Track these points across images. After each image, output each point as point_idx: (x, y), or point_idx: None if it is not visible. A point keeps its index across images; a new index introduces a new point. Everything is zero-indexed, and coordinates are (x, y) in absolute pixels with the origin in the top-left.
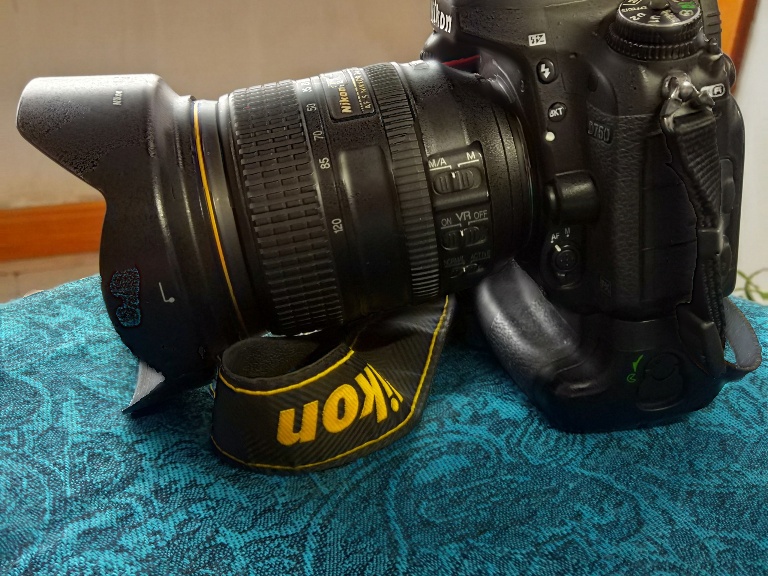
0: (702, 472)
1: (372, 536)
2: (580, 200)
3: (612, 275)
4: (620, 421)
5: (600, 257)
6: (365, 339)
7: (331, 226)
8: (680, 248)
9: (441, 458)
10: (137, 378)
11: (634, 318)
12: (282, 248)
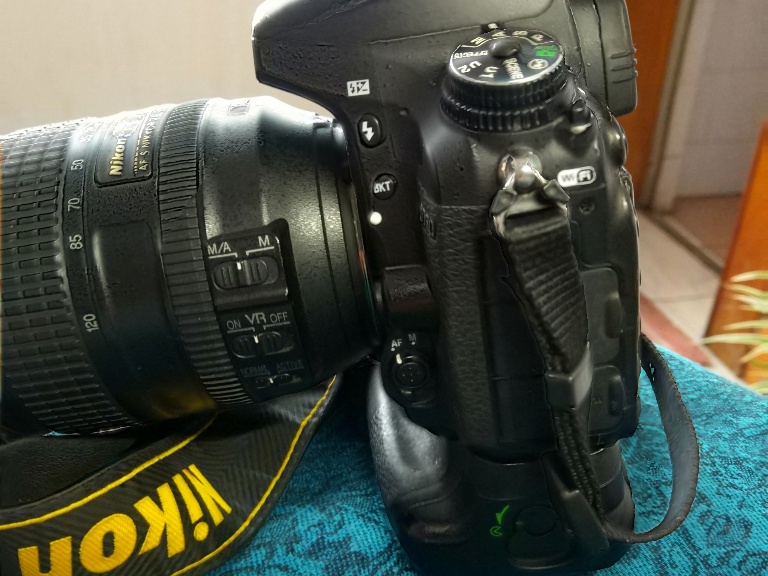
0: None
1: None
2: (413, 305)
3: (459, 405)
4: (495, 572)
5: (447, 378)
6: (221, 423)
7: (83, 323)
8: None
9: None
10: None
11: (496, 458)
12: (22, 347)
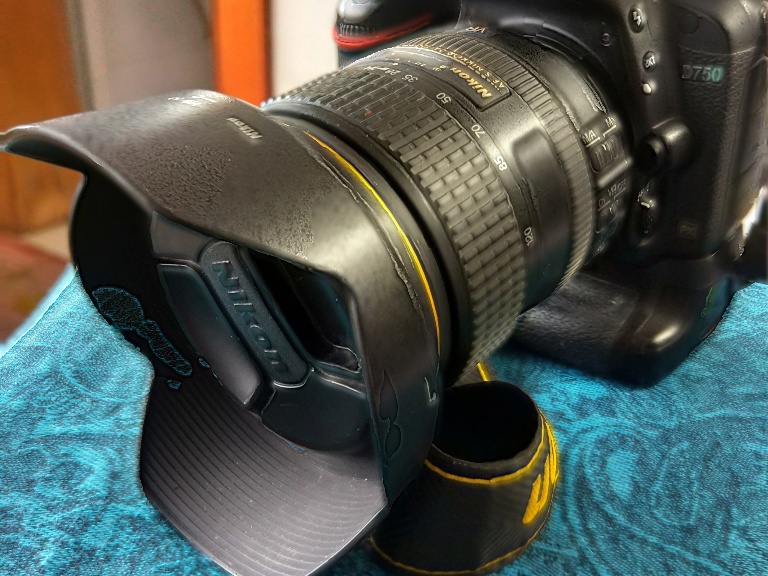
0: (767, 375)
1: (673, 570)
2: (678, 149)
3: (701, 217)
4: (676, 359)
5: (685, 203)
6: None
7: (524, 239)
8: (744, 175)
9: (607, 462)
10: (195, 545)
11: (706, 254)
12: (488, 283)
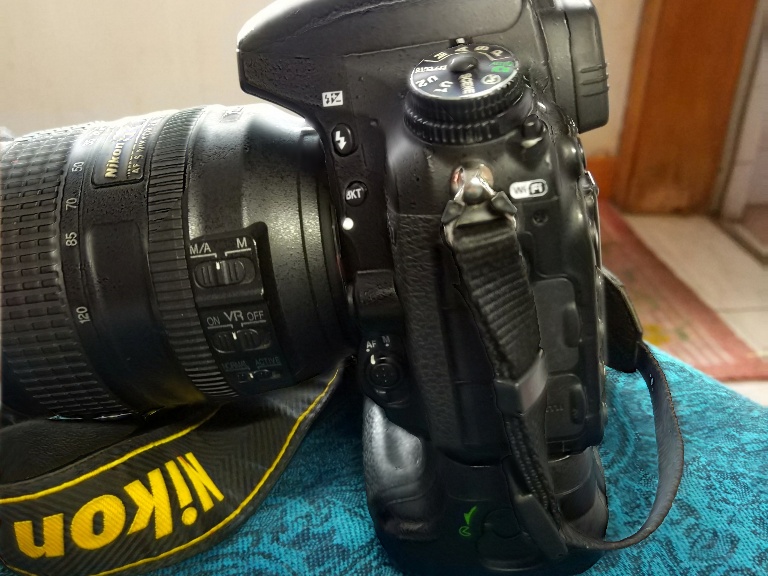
0: None
1: None
2: (382, 308)
3: None
4: (470, 572)
5: None
6: (223, 415)
7: (76, 314)
8: None
9: None
10: None
11: (463, 460)
12: (22, 335)
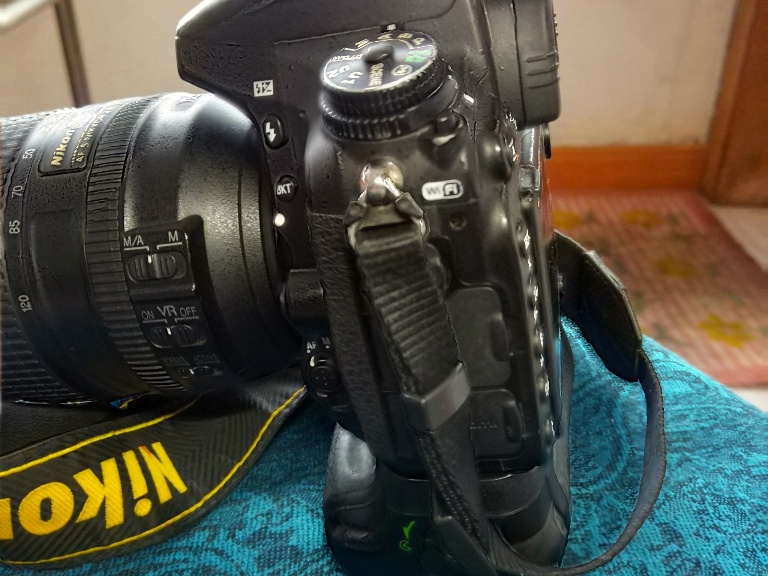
0: None
1: None
2: (312, 310)
3: None
4: None
5: None
6: (202, 405)
7: (19, 303)
8: None
9: None
10: None
11: (400, 472)
12: None
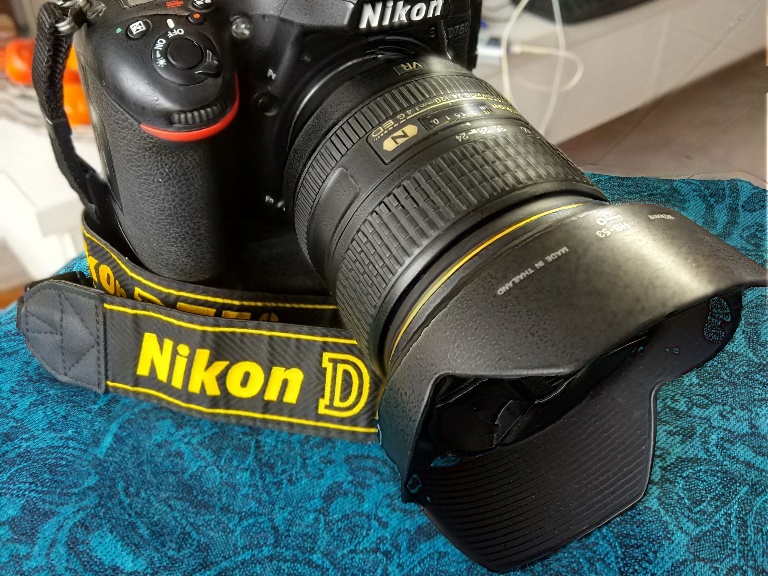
0: None
1: None
2: None
3: None
4: None
5: None
6: None
7: None
8: None
9: None
10: (558, 550)
11: None
12: None
